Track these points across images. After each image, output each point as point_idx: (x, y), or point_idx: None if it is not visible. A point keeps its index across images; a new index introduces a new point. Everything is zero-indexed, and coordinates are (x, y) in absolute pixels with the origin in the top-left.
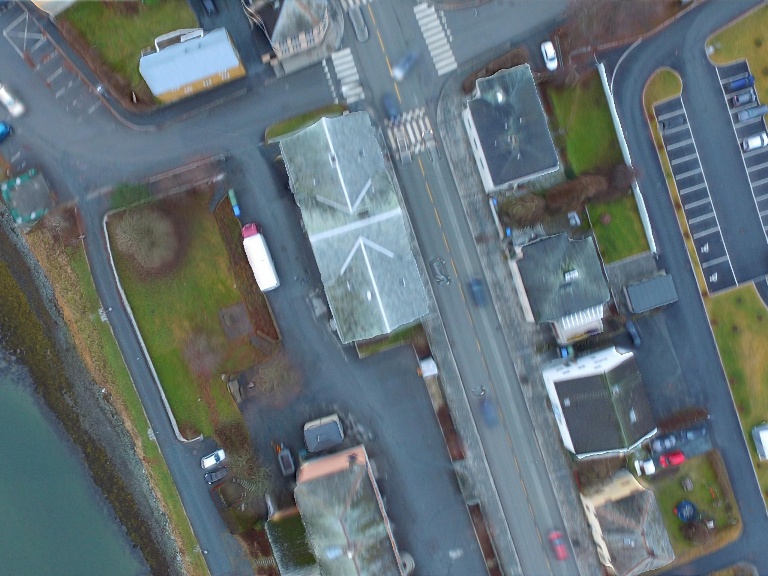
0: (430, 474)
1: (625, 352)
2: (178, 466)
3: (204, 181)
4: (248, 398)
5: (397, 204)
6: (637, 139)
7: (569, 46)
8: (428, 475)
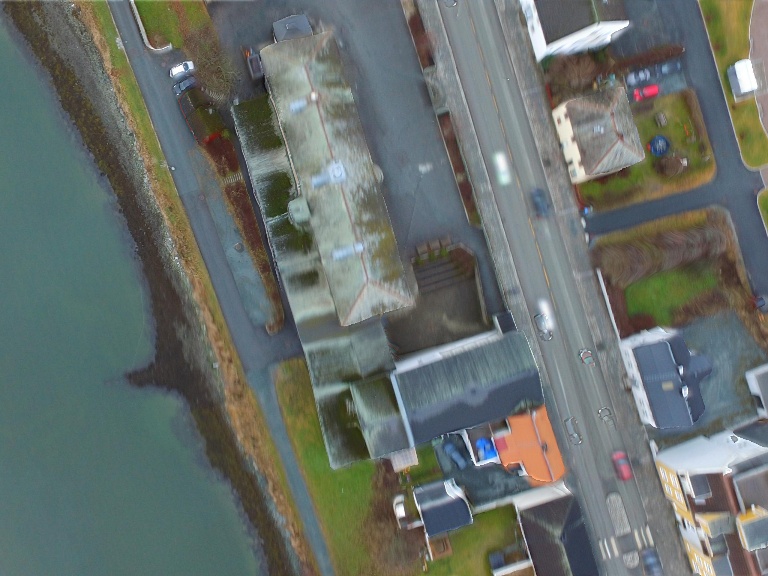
0: (401, 85)
1: None
2: (146, 78)
3: None
4: (218, 1)
5: None
6: None
7: None
8: (398, 86)
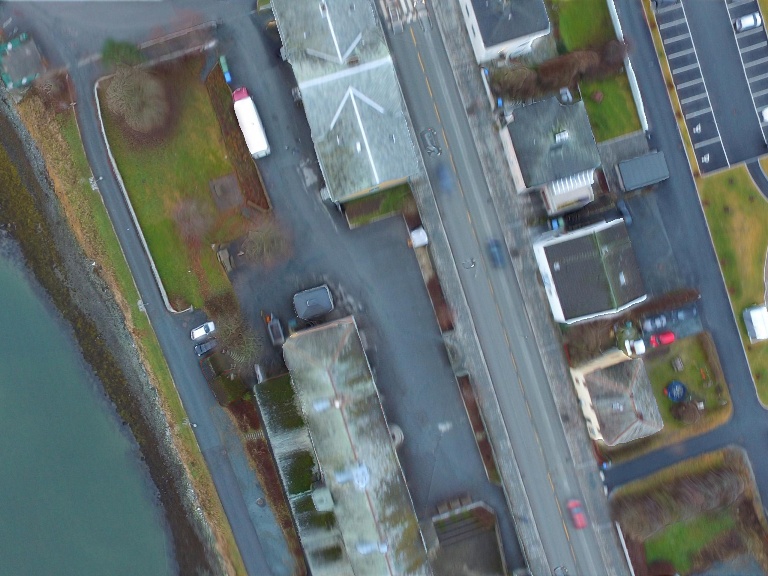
0: (420, 346)
1: None
2: (168, 338)
3: (195, 48)
4: (238, 268)
5: (387, 53)
6: (630, 17)
7: None
8: (418, 347)
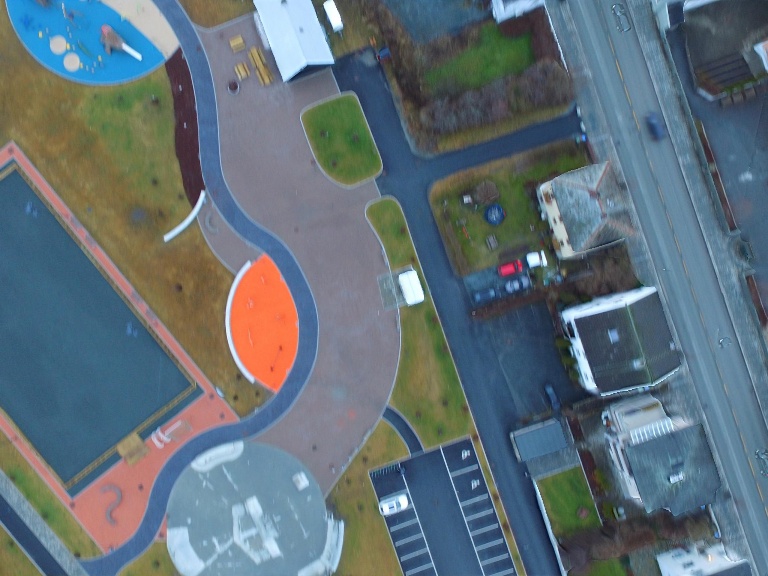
0: None
1: (560, 378)
2: None
3: None
4: None
5: None
6: None
7: None
8: None
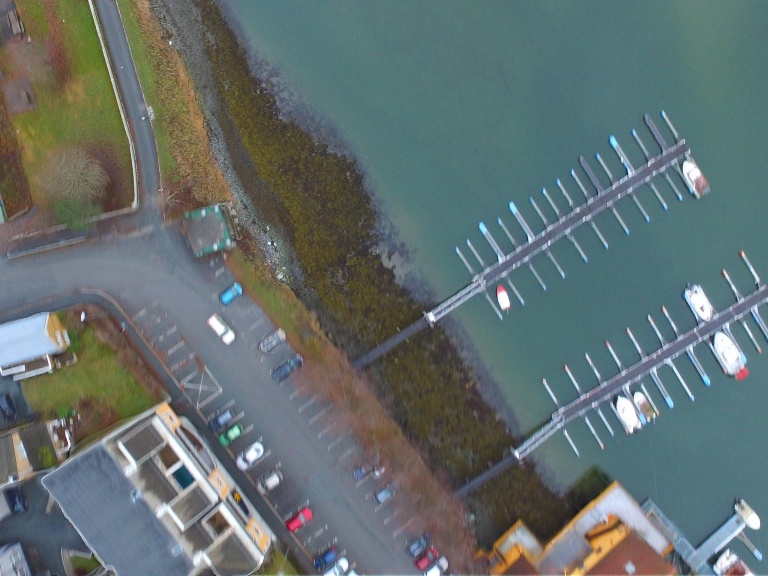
0: None
1: None
2: None
3: (33, 235)
4: (6, 15)
5: None
6: None
7: None
8: None
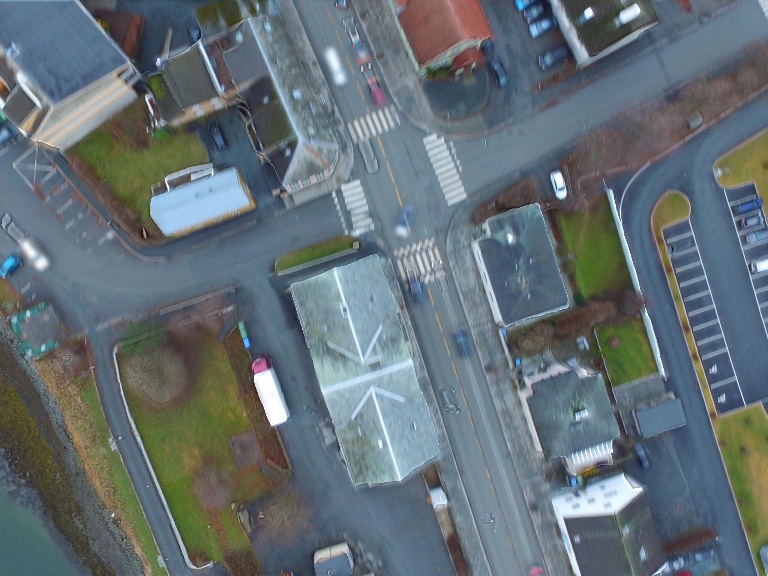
0: None
1: (634, 474)
2: None
3: (214, 312)
4: (258, 527)
5: (408, 355)
6: (646, 262)
7: (578, 172)
8: None
